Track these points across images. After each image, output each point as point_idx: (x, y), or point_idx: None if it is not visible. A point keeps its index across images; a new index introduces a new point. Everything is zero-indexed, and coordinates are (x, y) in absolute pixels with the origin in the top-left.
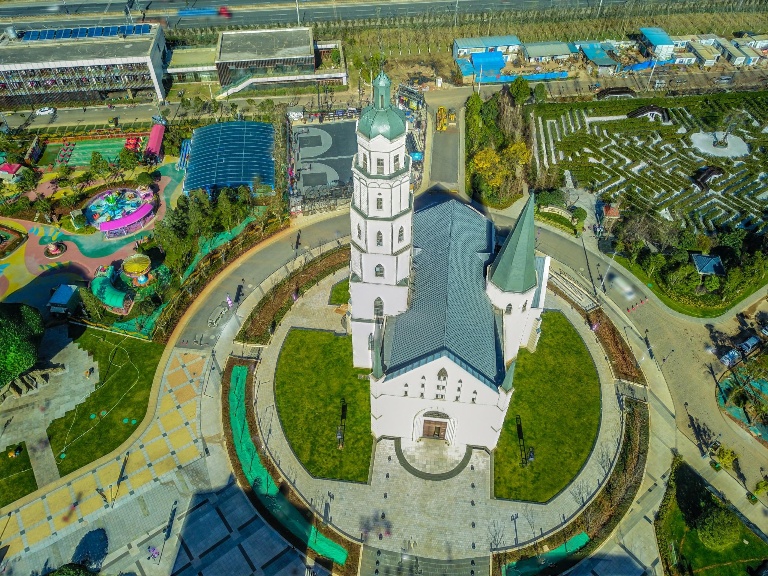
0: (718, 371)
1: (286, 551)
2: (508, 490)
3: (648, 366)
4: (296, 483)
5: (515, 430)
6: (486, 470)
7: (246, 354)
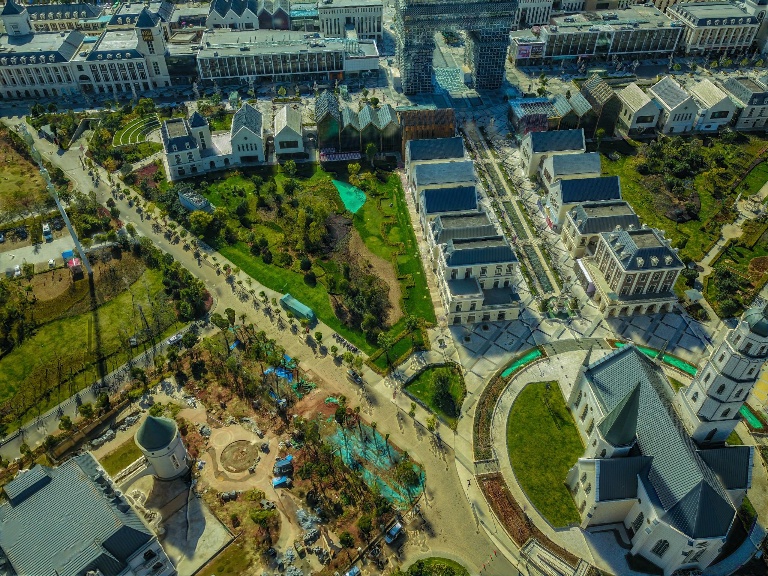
0: (422, 502)
1: (645, 344)
2: (551, 386)
3: (475, 495)
4: (664, 368)
5: (558, 420)
6: (566, 394)
7: (765, 440)
